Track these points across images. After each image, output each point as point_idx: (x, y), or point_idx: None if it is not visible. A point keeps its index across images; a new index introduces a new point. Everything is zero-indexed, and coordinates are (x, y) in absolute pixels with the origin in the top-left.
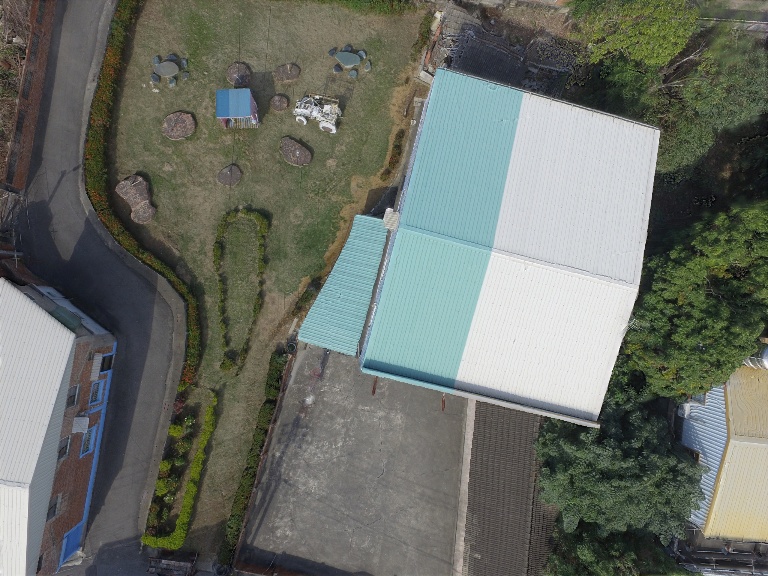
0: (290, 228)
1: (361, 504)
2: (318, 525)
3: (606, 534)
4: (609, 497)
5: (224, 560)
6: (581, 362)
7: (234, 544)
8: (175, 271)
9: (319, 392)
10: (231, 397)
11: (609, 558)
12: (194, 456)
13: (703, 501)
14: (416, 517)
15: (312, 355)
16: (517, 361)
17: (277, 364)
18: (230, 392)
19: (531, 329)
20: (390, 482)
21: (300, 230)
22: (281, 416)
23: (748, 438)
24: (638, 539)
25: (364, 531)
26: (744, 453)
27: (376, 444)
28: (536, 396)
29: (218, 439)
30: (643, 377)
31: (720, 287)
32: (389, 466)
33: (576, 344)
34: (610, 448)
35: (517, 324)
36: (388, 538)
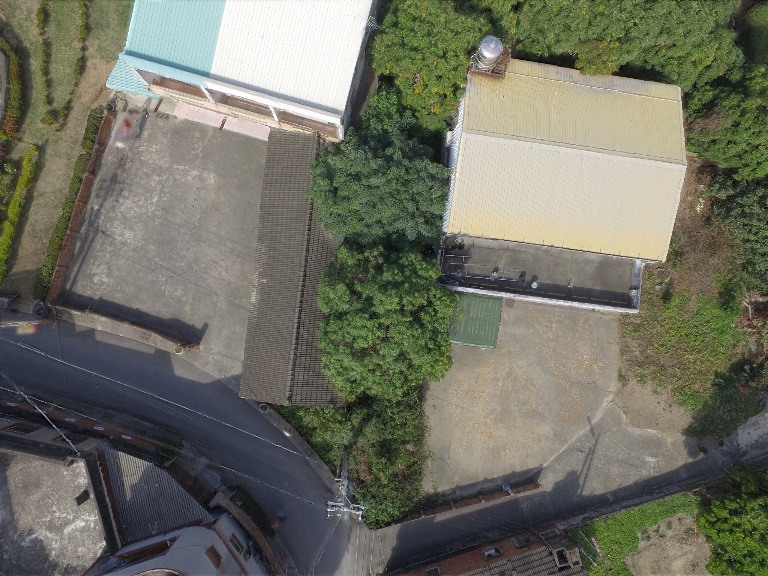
0: (113, 1)
1: (174, 255)
2: (133, 273)
3: (366, 240)
4: (359, 194)
5: (38, 295)
6: (326, 60)
7: (49, 282)
8: (1, 34)
9: (137, 151)
10: (53, 153)
11: (361, 252)
12: (12, 199)
13: (449, 204)
14: (226, 269)
15: (131, 118)
16: (267, 57)
17: (94, 119)
18: (52, 148)
19: (278, 26)
20: (202, 236)
21: (123, 3)
22: (100, 173)
23: (479, 132)
24: (398, 249)
25: (176, 280)
26: (476, 147)
27: (189, 200)
28: (285, 91)
29: (39, 191)
30: (406, 102)
31: (464, 5)
32: (201, 221)
33: (320, 42)
34: (362, 151)
35: (264, 20)
36: (199, 288)
